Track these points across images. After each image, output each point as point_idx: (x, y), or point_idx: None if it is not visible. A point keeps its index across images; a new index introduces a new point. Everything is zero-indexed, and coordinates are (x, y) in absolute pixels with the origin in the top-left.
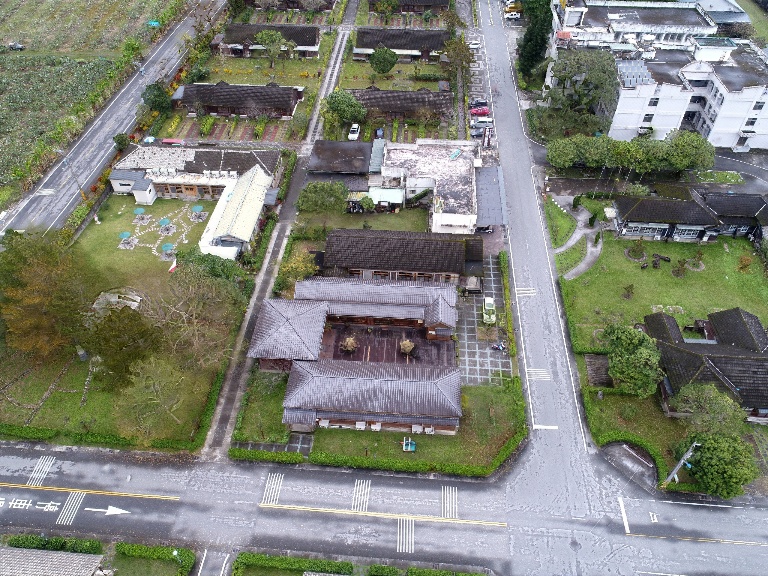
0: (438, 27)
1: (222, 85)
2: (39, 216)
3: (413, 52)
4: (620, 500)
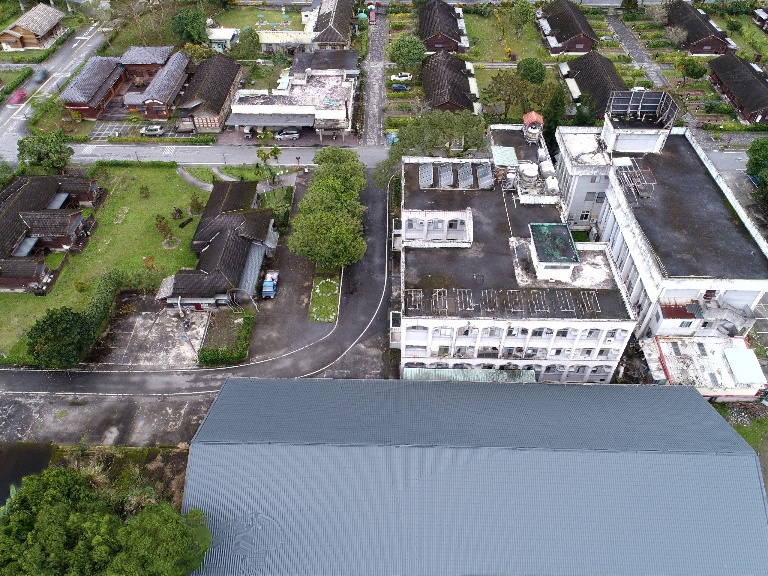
0: (697, 120)
1: (437, 8)
2: None
3: (576, 93)
4: None
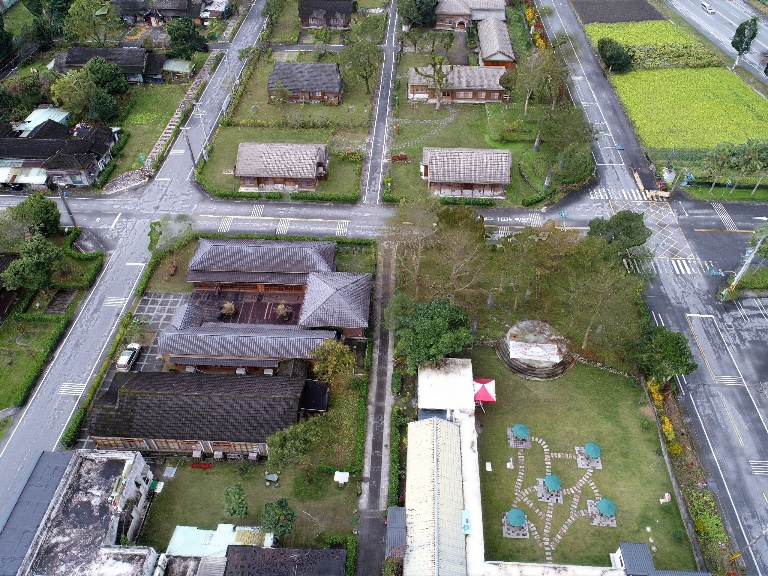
0: None
1: None
2: (765, 508)
3: None
4: (113, 226)
